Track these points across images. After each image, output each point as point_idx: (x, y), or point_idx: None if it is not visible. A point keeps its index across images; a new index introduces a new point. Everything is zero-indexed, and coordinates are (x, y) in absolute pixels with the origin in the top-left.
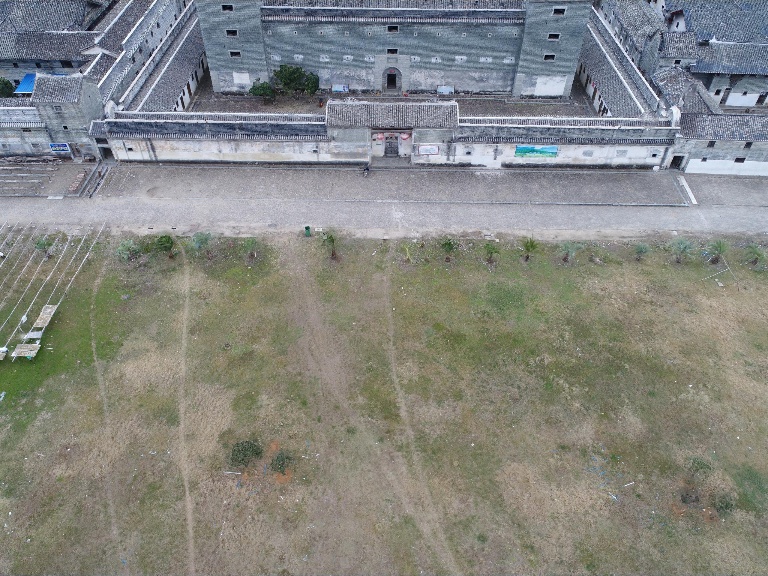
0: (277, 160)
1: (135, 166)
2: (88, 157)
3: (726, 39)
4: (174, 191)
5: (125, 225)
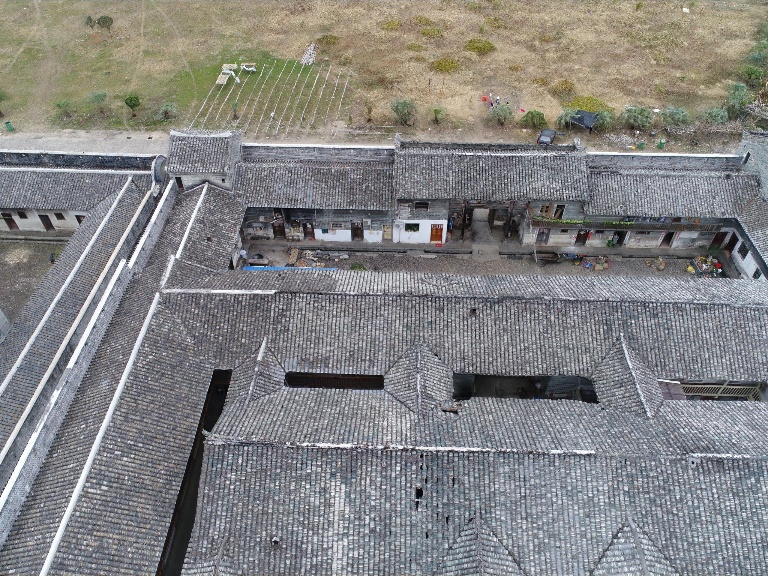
0: None
1: None
2: None
3: None
4: None
5: None
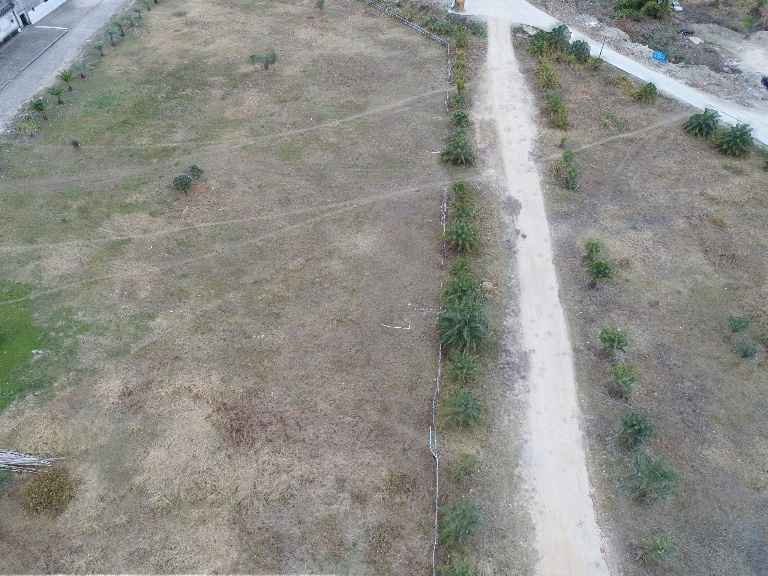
0: None
1: None
2: None
3: None
4: None
5: None
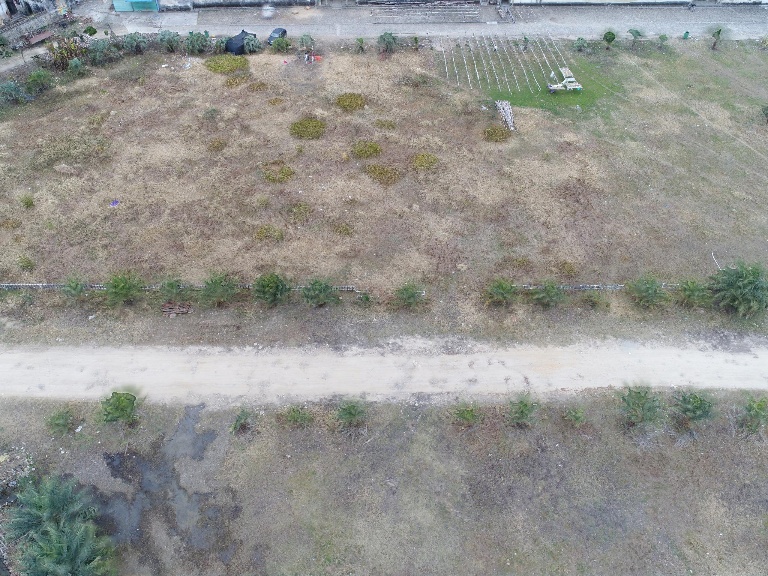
0: (626, 2)
1: (525, 8)
2: (492, 1)
3: None
4: (569, 19)
5: (557, 35)
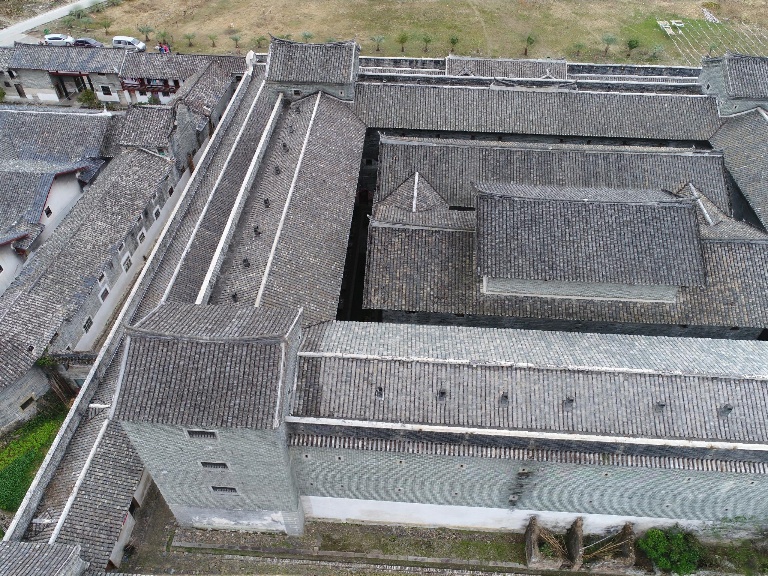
0: None
1: None
2: None
3: (38, 161)
4: None
5: None
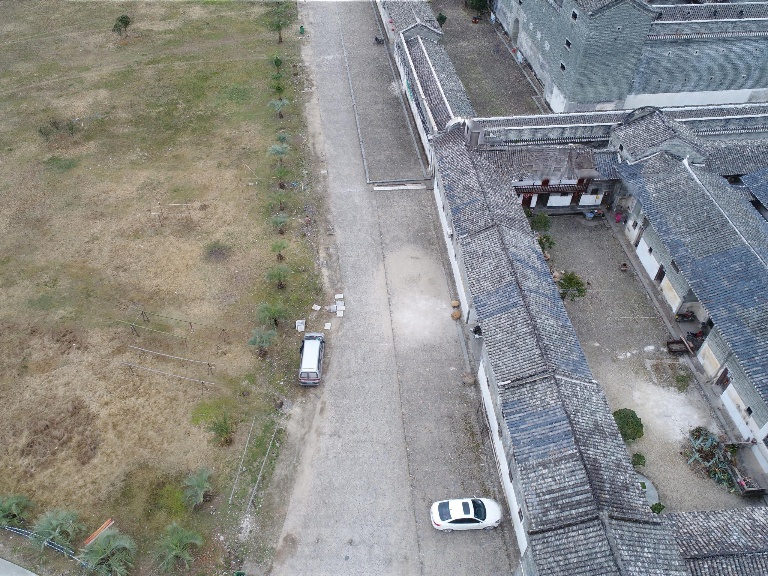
0: None
1: None
2: None
3: None
4: None
5: None
